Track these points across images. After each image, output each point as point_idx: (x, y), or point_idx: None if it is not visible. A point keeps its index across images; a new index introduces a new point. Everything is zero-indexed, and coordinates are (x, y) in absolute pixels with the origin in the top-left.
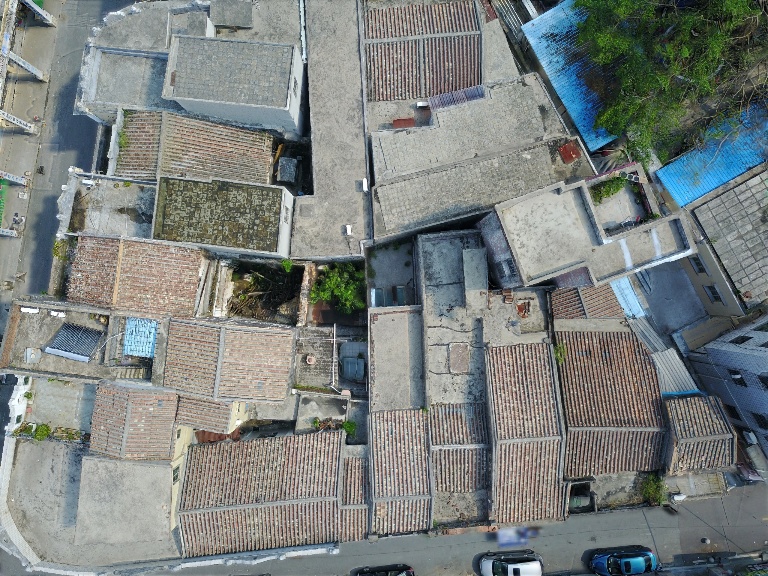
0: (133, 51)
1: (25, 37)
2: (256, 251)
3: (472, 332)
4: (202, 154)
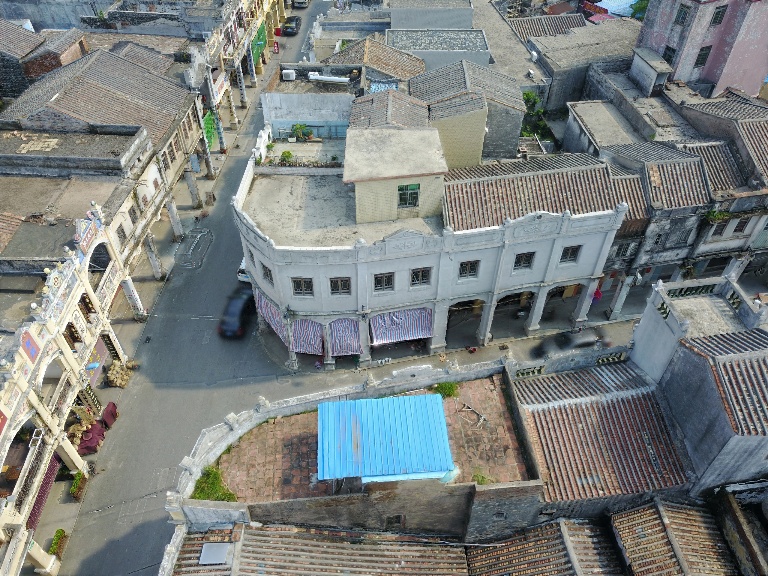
0: (346, 24)
1: (233, 92)
2: None
3: (662, 108)
4: None
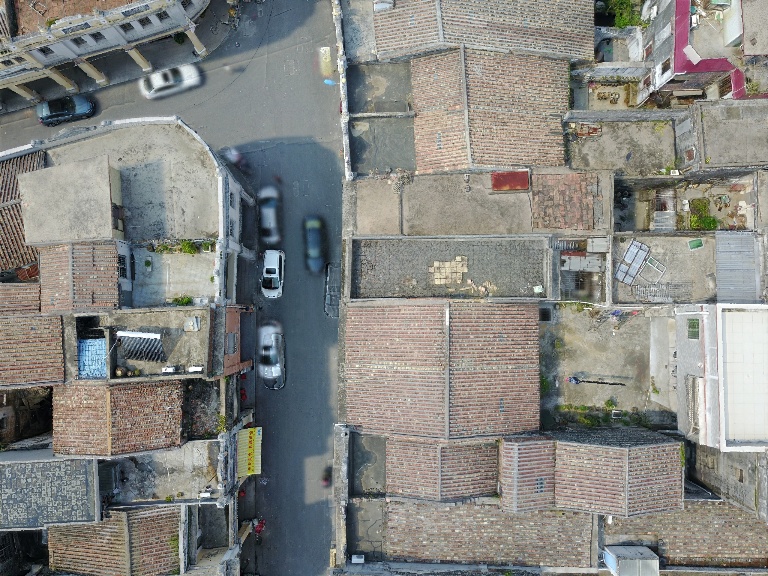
0: None
1: None
2: None
3: None
4: (98, 542)
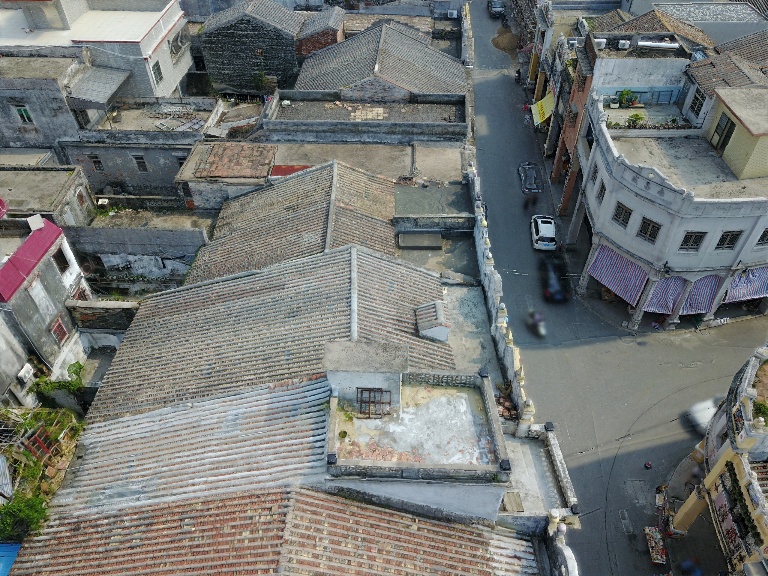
0: (573, 4)
1: None
2: (753, 21)
3: None
4: None
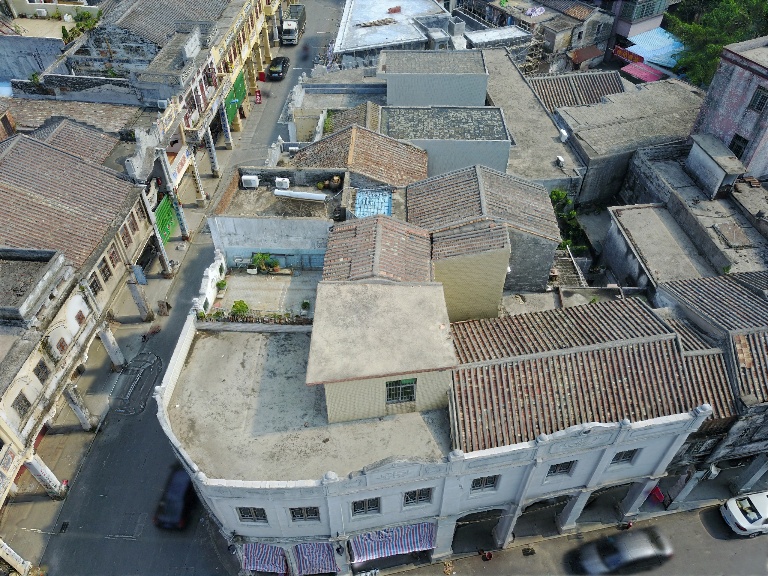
0: (334, 87)
1: (204, 155)
2: (487, 140)
3: (731, 217)
4: None
